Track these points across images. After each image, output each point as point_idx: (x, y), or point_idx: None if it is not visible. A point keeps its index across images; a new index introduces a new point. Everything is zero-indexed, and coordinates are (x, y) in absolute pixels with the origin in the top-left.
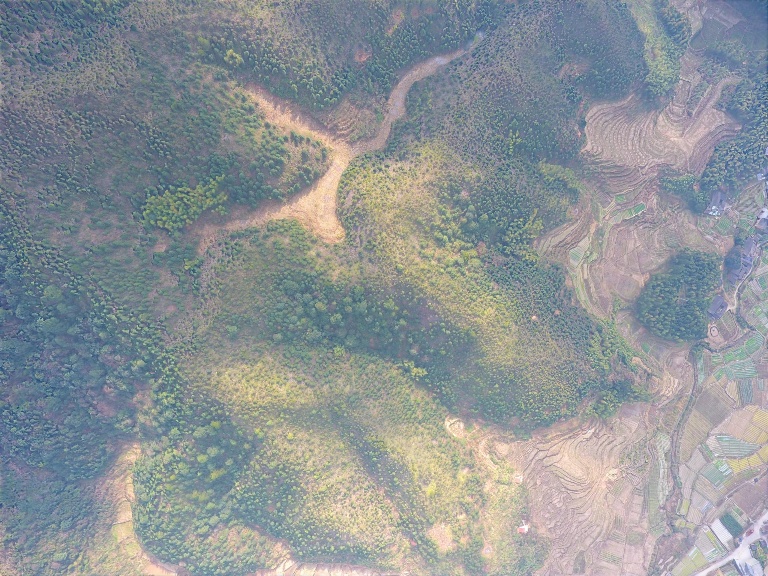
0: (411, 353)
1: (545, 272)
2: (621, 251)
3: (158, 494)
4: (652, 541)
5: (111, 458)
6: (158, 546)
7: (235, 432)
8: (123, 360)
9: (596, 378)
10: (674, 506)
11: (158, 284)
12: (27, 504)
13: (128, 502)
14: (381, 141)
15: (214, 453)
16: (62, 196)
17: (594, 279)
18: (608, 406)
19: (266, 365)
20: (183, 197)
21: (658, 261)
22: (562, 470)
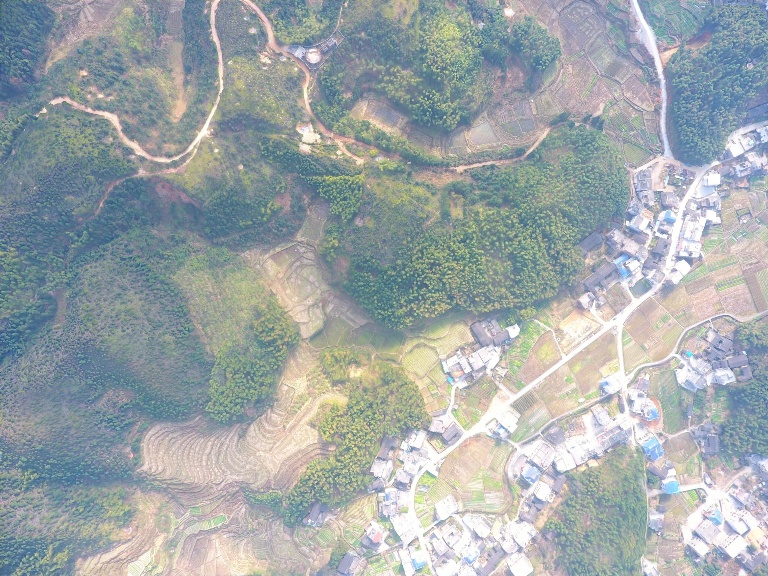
0: None
1: None
2: (198, 561)
3: None
4: None
5: None
6: None
7: None
8: None
9: None
10: None
11: None
12: None
13: None
14: None
15: None
16: None
17: None
18: None
19: None
20: None
21: (237, 575)
22: None
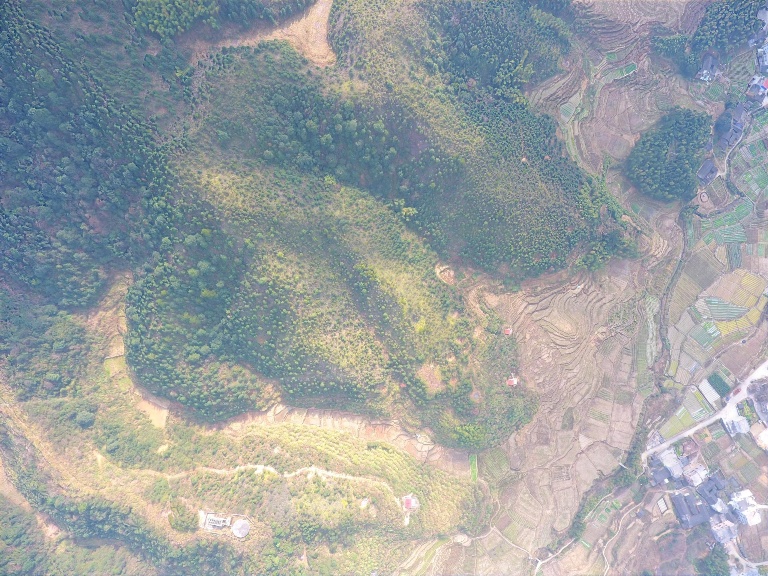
0: (401, 189)
1: (535, 117)
2: (612, 112)
3: (149, 311)
4: (640, 401)
5: (103, 287)
6: (150, 373)
7: (225, 244)
8: (115, 164)
9: (585, 228)
10: (662, 367)
11: (149, 86)
12: (20, 319)
13: (120, 336)
14: None
15: (205, 267)
16: None
17: (585, 137)
18: (597, 257)
19: (256, 180)
20: (174, 0)
21: (649, 122)
22: (551, 324)
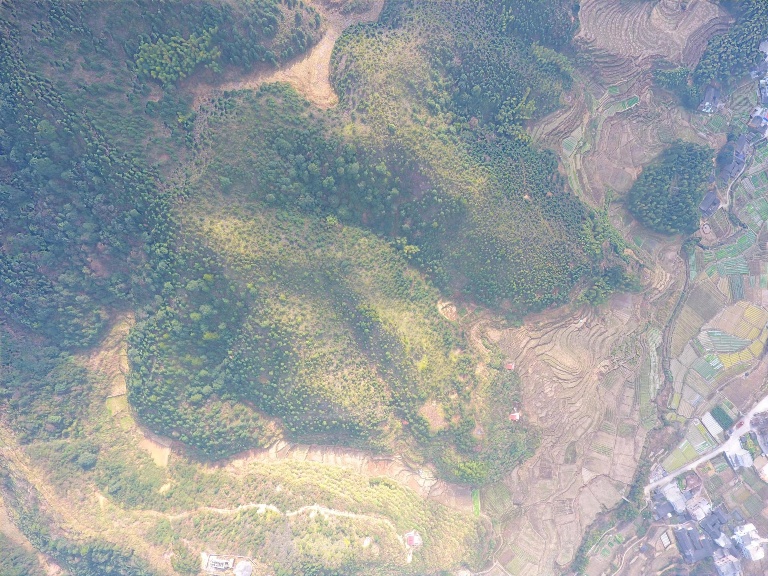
0: (403, 228)
1: (538, 154)
2: (614, 144)
3: (151, 354)
4: (643, 434)
5: (105, 327)
6: (152, 414)
7: (228, 288)
8: (116, 210)
9: (588, 263)
10: (665, 400)
11: (151, 133)
12: (22, 363)
13: (122, 375)
14: (375, 14)
15: (207, 310)
16: (56, 33)
17: (587, 170)
18: (600, 292)
19: (259, 224)
20: (176, 47)
21: (651, 155)
22: (554, 359)
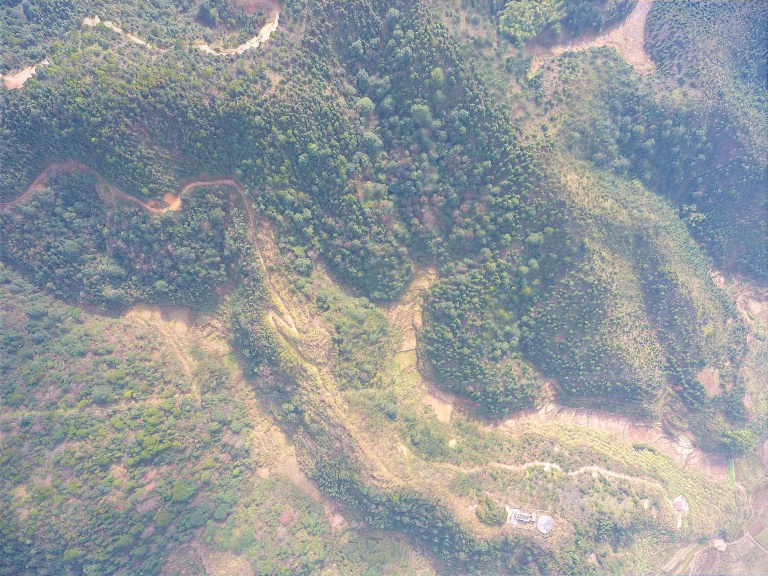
0: (695, 195)
1: None
2: None
3: (472, 306)
4: None
5: (408, 281)
6: (452, 367)
7: (560, 243)
8: (468, 162)
9: None
10: None
11: (511, 87)
12: (347, 310)
13: (413, 331)
14: None
15: (536, 264)
16: None
17: None
18: None
19: (589, 181)
20: (536, 5)
21: None
22: None
